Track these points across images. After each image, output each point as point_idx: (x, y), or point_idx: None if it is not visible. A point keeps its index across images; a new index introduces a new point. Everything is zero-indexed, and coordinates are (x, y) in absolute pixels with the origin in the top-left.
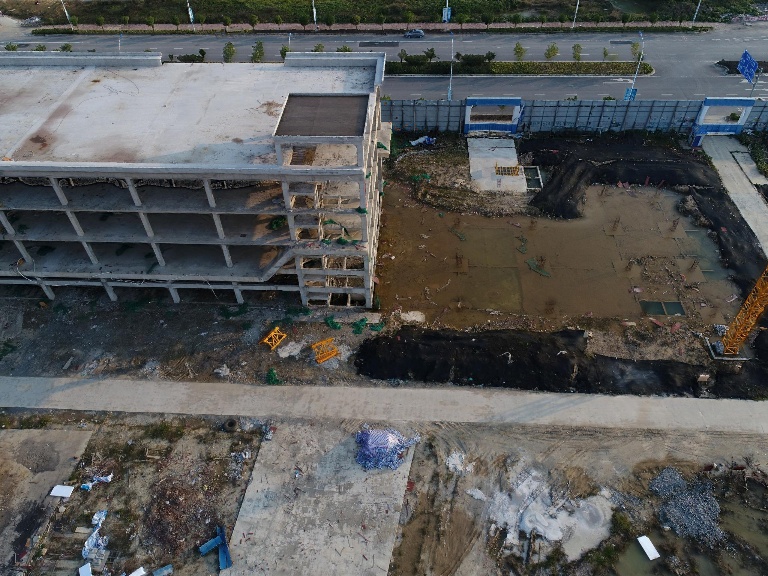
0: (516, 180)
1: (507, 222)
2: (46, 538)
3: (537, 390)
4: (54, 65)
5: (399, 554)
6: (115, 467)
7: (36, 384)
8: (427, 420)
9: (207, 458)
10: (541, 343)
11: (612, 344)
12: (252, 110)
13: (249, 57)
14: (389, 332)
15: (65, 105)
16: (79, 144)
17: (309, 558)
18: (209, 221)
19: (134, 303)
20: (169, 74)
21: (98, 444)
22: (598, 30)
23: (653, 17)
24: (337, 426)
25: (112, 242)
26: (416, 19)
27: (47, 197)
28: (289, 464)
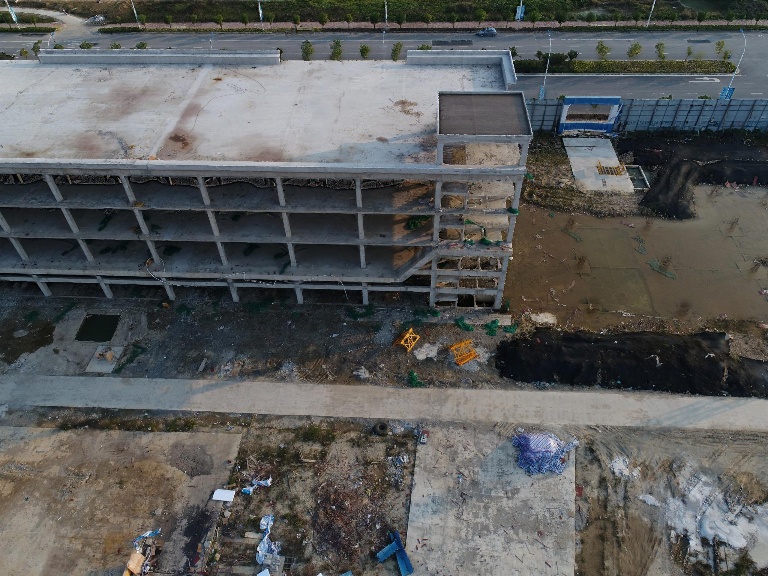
0: (621, 180)
1: (620, 222)
2: (216, 543)
3: (689, 393)
4: (170, 63)
5: (582, 561)
6: (272, 471)
7: (174, 386)
8: (582, 424)
9: (364, 462)
10: (687, 346)
11: (755, 347)
12: (387, 109)
13: (323, 56)
14: (524, 334)
15: (194, 103)
16: (221, 143)
17: (490, 565)
18: (348, 221)
19: (257, 304)
20: (290, 72)
21: (250, 447)
22: (673, 28)
23: (730, 15)
24: (491, 430)
25: (245, 242)
26: (486, 17)
27: (187, 197)
28: (450, 468)
